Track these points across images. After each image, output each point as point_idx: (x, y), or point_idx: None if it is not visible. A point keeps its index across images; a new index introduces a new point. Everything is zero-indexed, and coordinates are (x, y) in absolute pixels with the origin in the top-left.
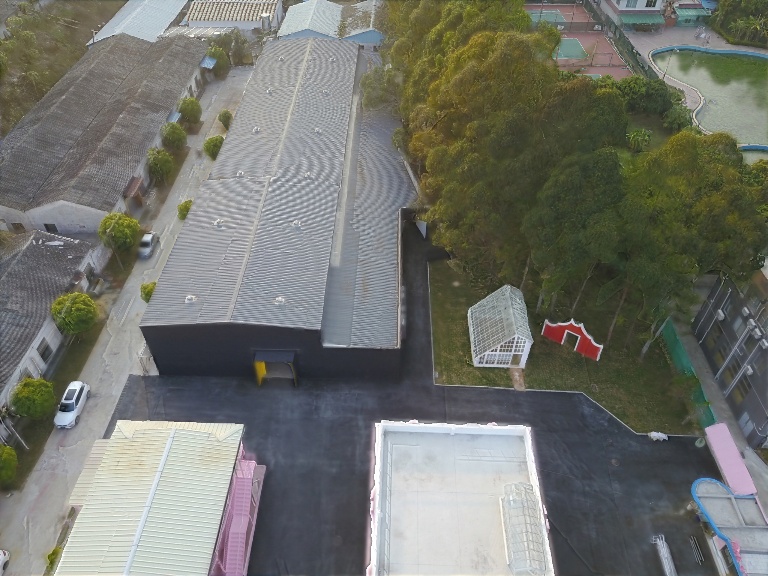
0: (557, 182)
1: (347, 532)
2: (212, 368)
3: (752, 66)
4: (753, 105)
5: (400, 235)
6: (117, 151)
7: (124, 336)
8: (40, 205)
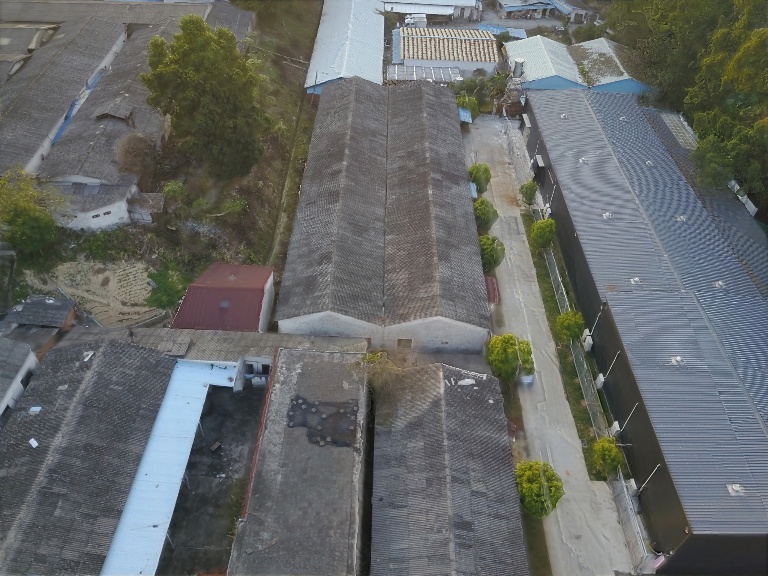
0: None
1: None
2: (733, 569)
3: None
4: None
5: None
6: (453, 241)
7: (571, 508)
8: (409, 320)
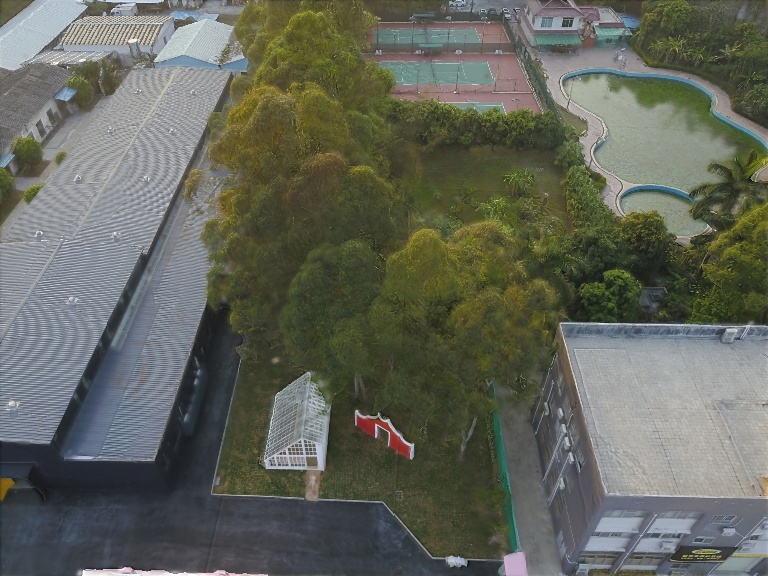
0: (300, 279)
1: None
2: None
3: (668, 92)
4: (660, 137)
5: None
6: None
7: None
8: None
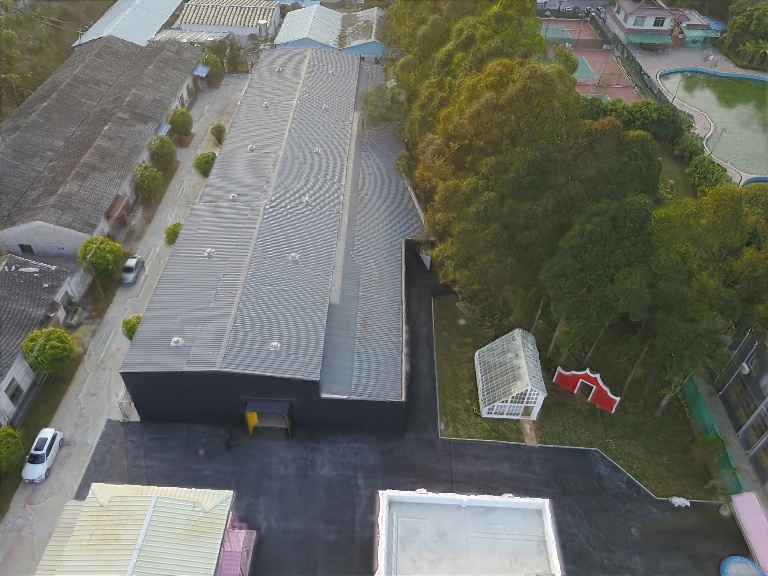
0: (584, 231)
1: None
2: (199, 415)
3: (761, 91)
4: (763, 133)
5: (404, 270)
6: (101, 166)
7: (103, 374)
8: (15, 225)
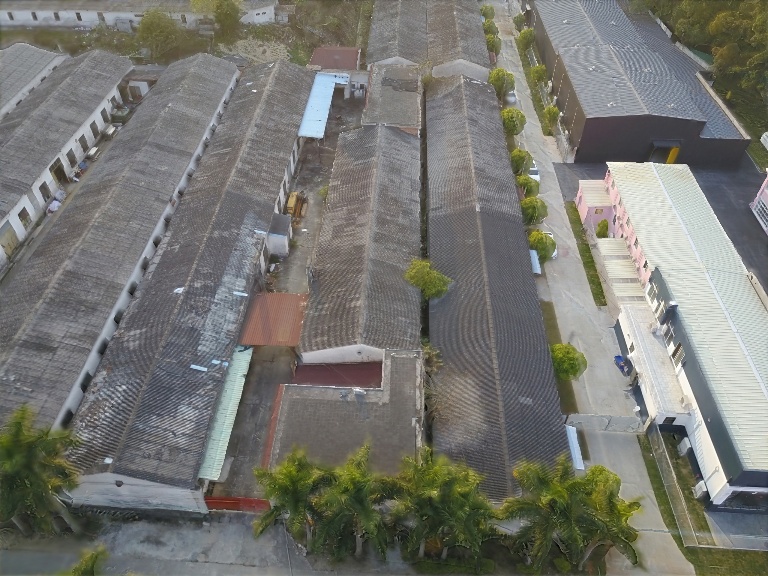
0: None
1: (749, 235)
2: (614, 156)
3: None
4: None
5: (709, 85)
6: (469, 34)
7: (532, 144)
8: (443, 63)
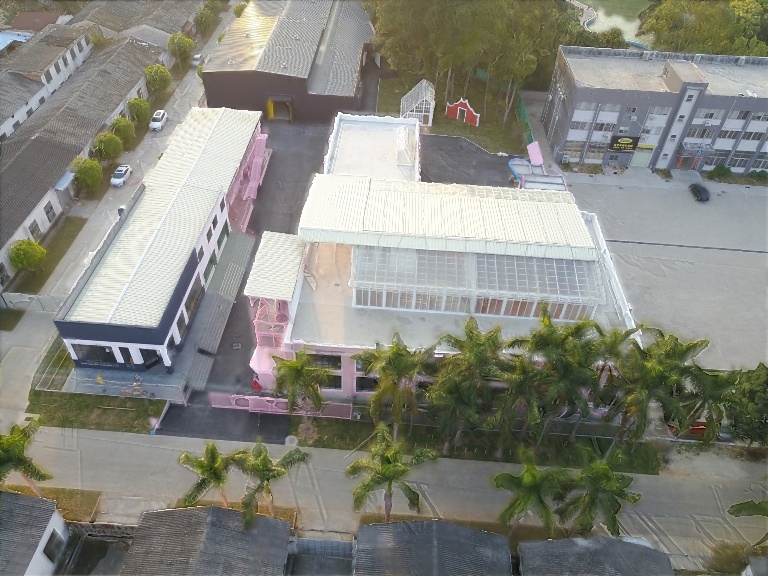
0: None
1: None
2: None
3: None
4: (632, 21)
5: (361, 54)
6: (176, 6)
7: (186, 99)
8: (130, 28)
